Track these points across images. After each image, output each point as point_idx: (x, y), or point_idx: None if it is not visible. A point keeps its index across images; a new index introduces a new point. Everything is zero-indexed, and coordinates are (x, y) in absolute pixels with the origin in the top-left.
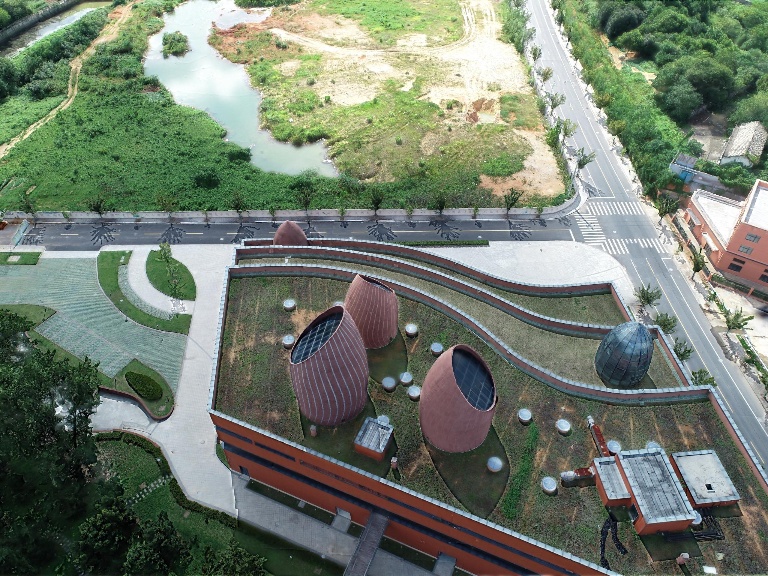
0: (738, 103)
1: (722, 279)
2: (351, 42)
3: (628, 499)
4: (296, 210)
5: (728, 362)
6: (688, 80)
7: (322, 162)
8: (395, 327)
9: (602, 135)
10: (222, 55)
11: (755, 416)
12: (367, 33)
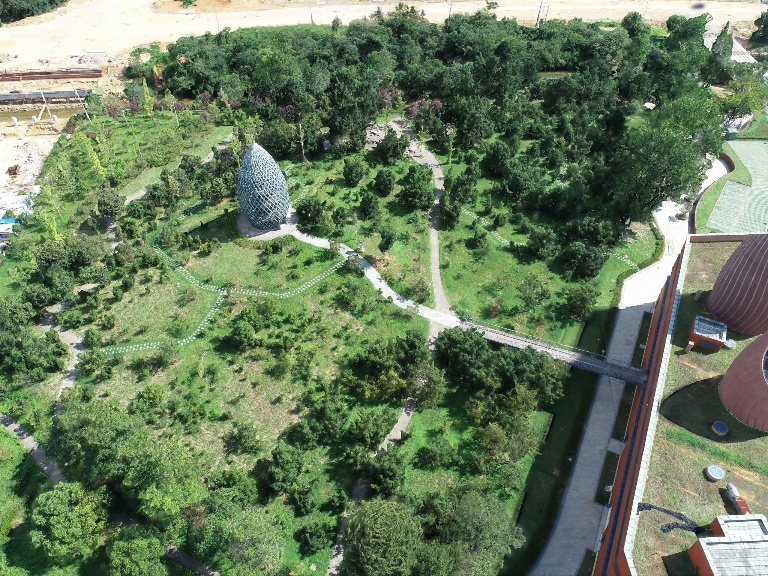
0: None
1: None
2: None
3: None
4: None
5: None
6: None
7: None
8: None
9: None
10: None
11: None
12: None
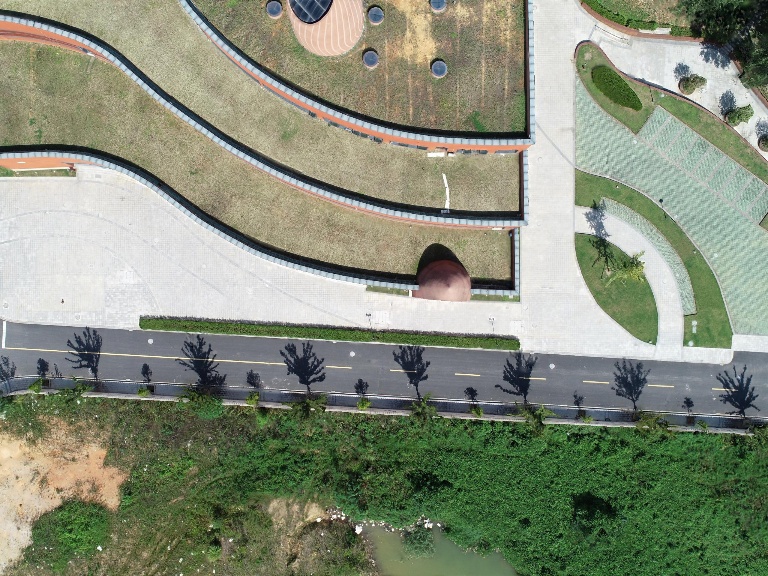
0: None
1: None
2: None
3: None
4: None
5: None
6: None
7: None
8: None
9: None
10: None
11: None
12: None
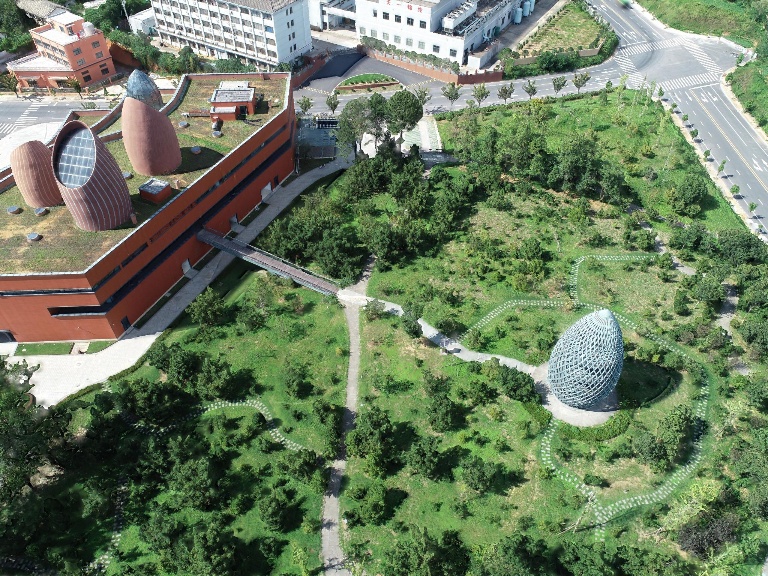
0: None
1: None
2: None
3: (236, 108)
4: None
5: None
6: None
7: None
8: None
9: None
10: None
11: None
12: None
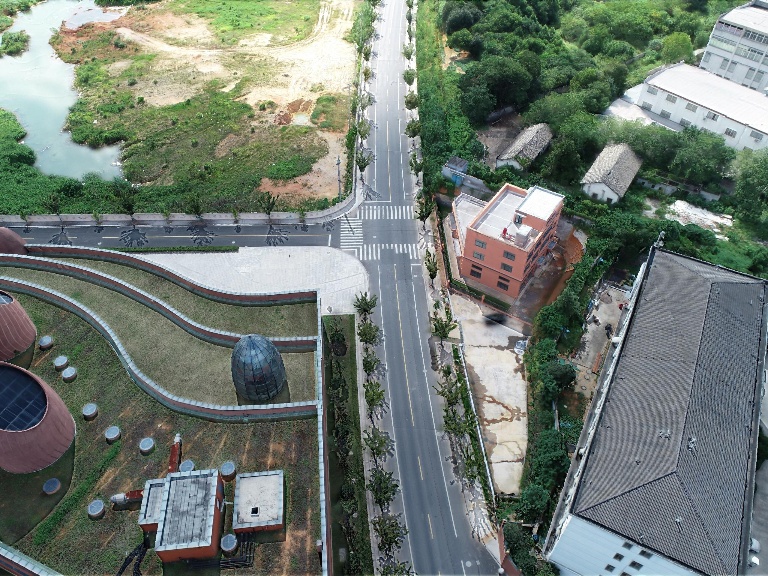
0: (530, 104)
1: (463, 286)
2: (192, 42)
3: None
4: (50, 215)
5: (432, 373)
6: (486, 81)
7: (110, 165)
8: (19, 340)
9: (406, 137)
10: (57, 55)
11: (435, 430)
12: (213, 32)
